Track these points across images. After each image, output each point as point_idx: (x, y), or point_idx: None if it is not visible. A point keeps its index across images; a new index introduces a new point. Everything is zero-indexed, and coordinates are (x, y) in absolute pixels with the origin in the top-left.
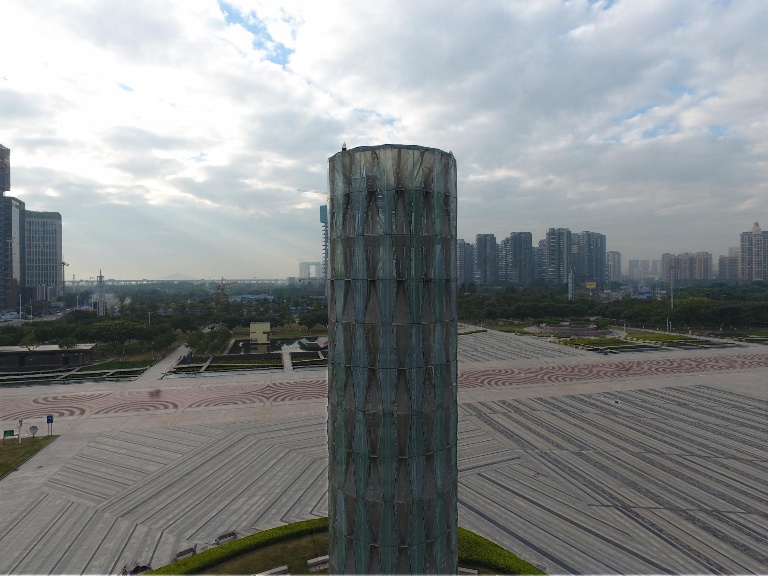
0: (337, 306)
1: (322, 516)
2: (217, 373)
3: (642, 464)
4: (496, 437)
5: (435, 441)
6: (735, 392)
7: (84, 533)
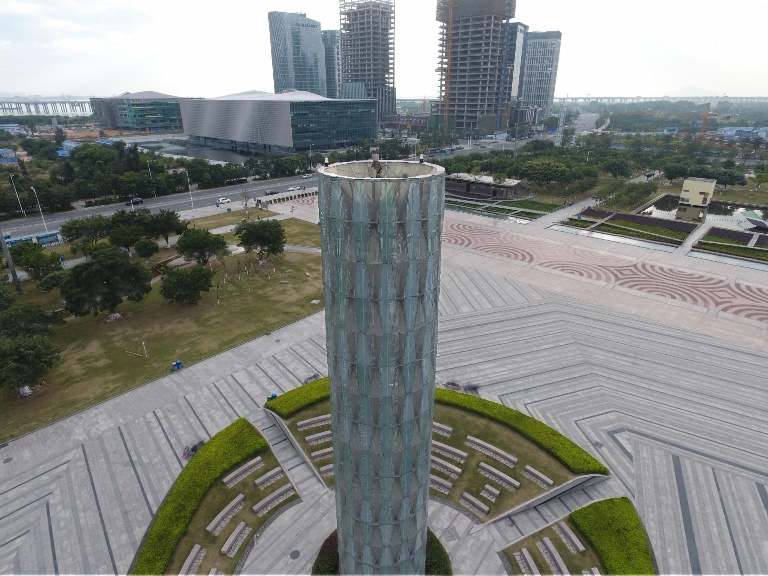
0: None
1: (530, 413)
2: (601, 234)
3: None
4: None
5: (361, 416)
6: None
7: None
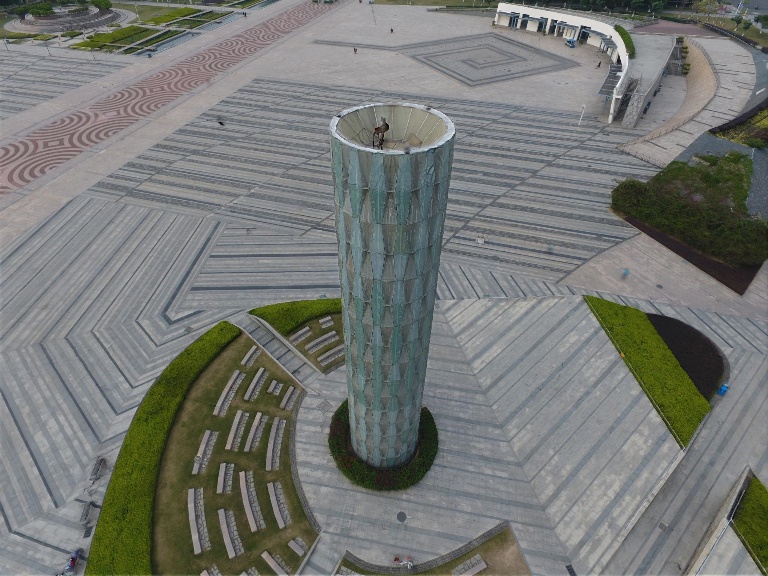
0: (396, 271)
1: (148, 381)
2: None
3: (294, 183)
4: (177, 211)
5: None
6: (283, 80)
7: None
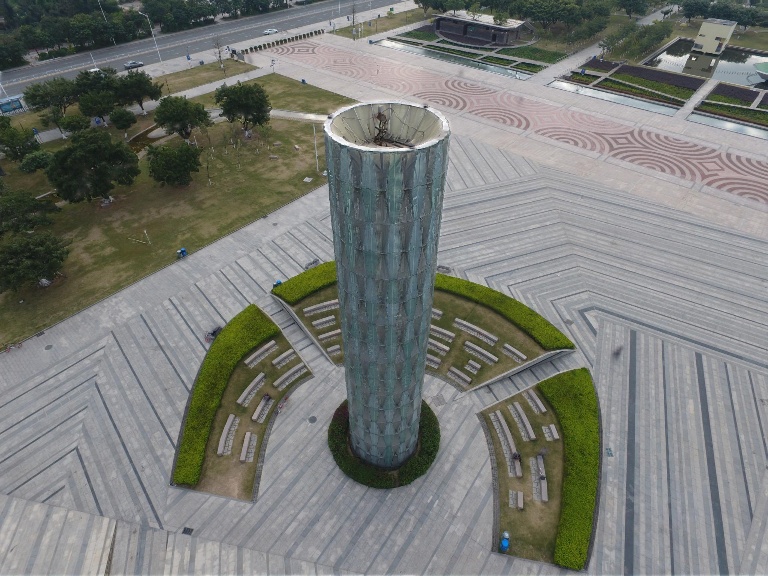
0: None
1: (512, 294)
2: (603, 93)
3: None
4: None
5: (369, 338)
6: None
7: None
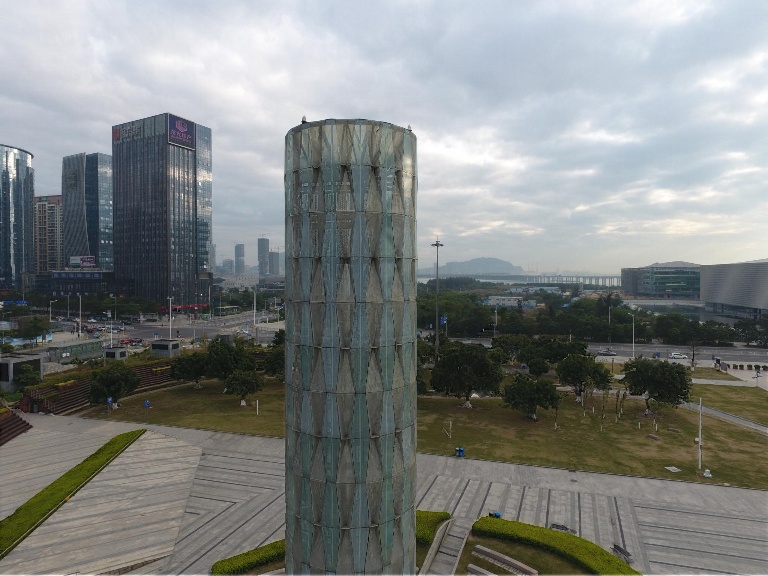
0: None
1: None
2: None
3: None
4: None
5: None
6: None
7: (763, 562)
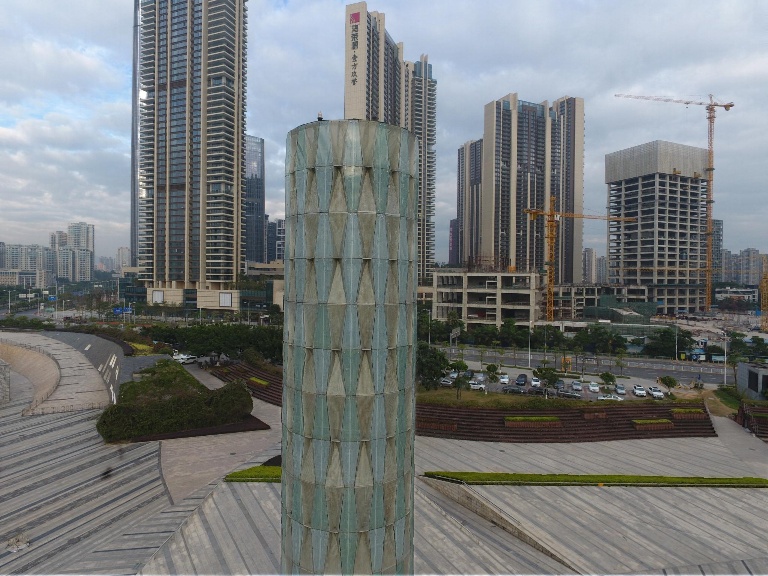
0: None
1: None
2: None
3: None
4: None
5: None
6: None
7: None
